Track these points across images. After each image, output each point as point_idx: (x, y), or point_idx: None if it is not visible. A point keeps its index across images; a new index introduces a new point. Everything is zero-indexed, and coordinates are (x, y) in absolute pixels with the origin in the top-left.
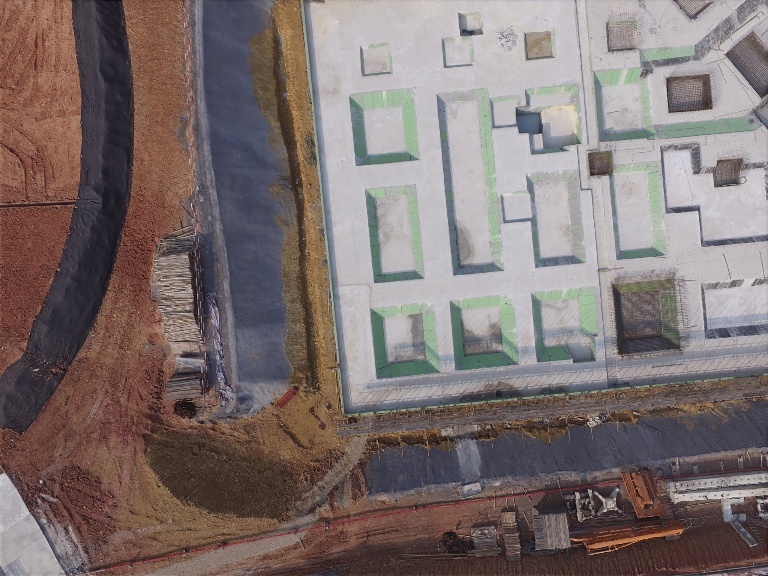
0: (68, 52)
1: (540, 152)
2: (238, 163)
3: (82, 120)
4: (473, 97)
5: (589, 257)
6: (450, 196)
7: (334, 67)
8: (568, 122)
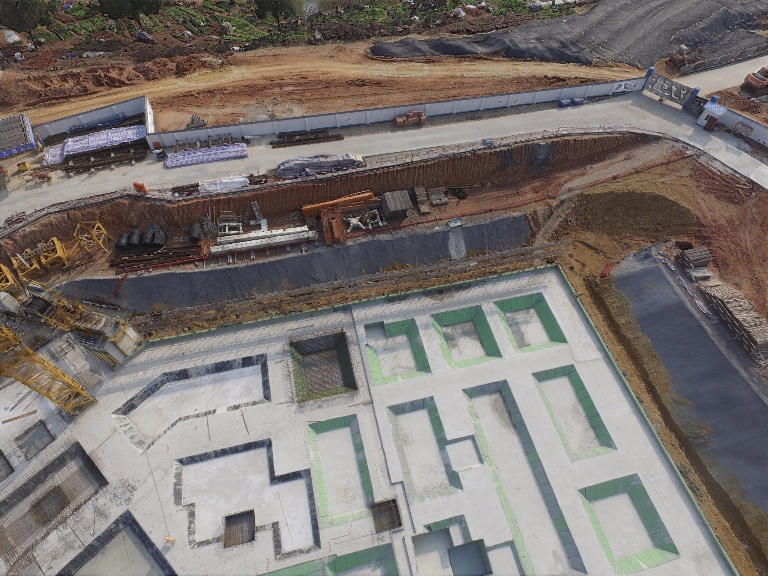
0: None
1: (453, 521)
2: (759, 441)
3: None
4: None
5: (384, 413)
6: (531, 458)
7: None
8: (422, 573)
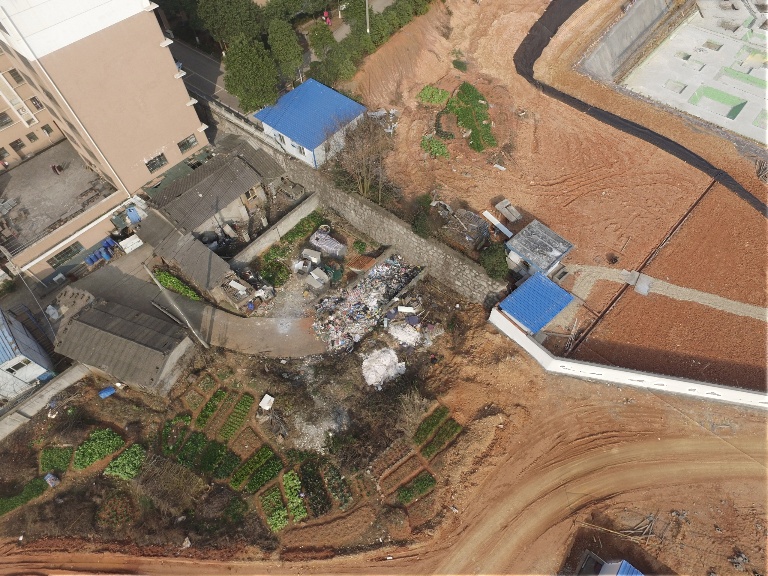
0: (616, 132)
1: None
2: None
3: (663, 149)
4: (721, 74)
5: None
6: None
7: (666, 99)
8: (755, 62)
